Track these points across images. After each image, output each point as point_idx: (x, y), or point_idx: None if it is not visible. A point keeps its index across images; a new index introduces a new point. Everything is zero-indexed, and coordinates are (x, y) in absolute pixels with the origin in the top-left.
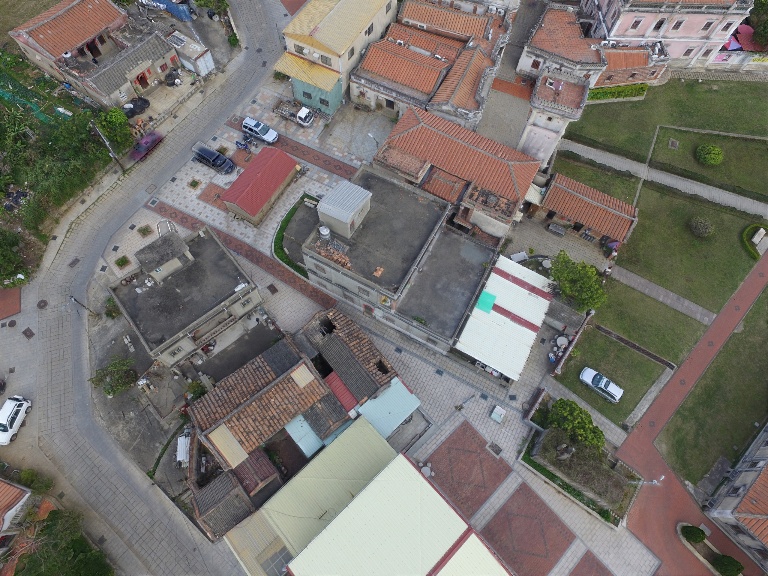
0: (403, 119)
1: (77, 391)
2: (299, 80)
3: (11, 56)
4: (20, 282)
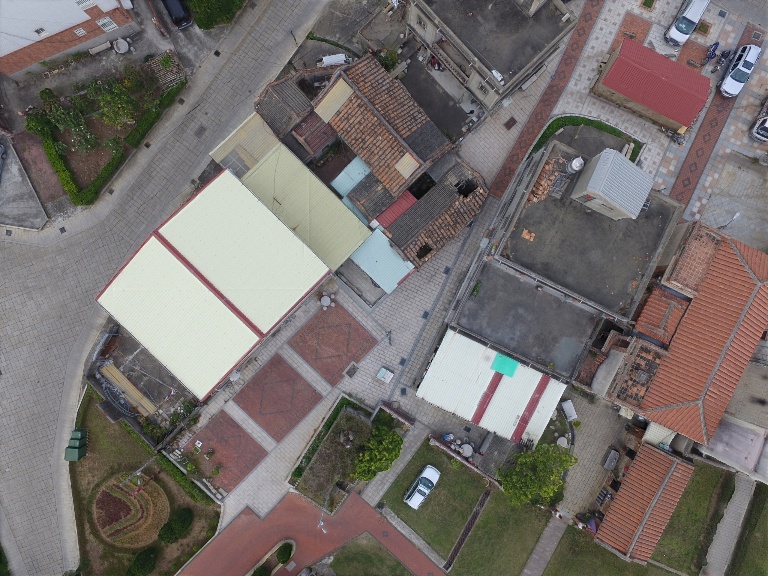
0: (767, 259)
1: None
2: None
3: None
4: None
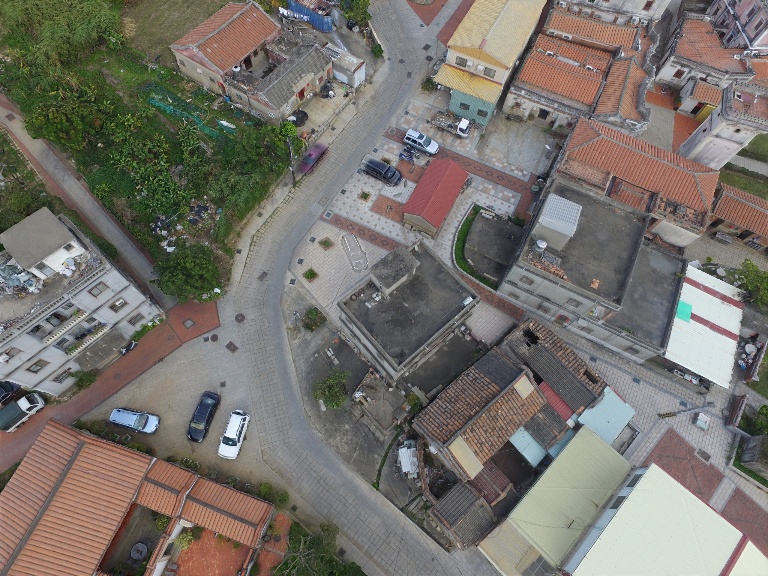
0: (578, 131)
1: (290, 404)
2: (461, 92)
3: (165, 69)
4: (216, 296)
